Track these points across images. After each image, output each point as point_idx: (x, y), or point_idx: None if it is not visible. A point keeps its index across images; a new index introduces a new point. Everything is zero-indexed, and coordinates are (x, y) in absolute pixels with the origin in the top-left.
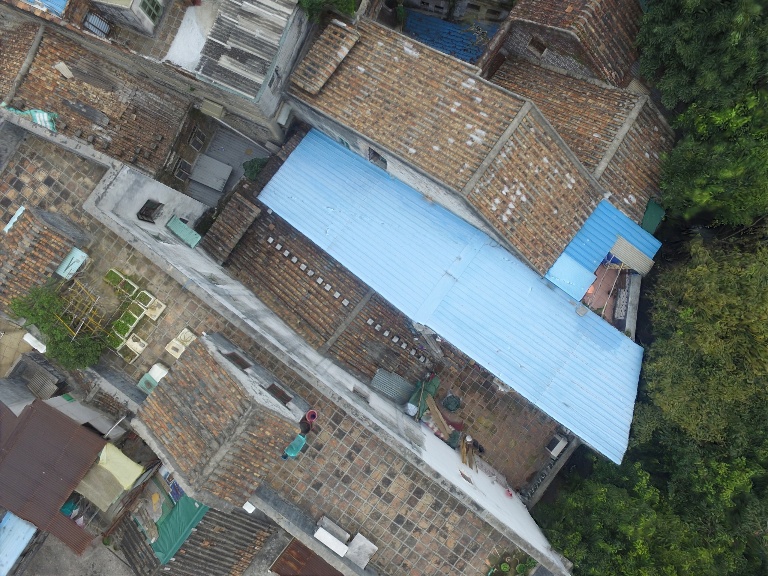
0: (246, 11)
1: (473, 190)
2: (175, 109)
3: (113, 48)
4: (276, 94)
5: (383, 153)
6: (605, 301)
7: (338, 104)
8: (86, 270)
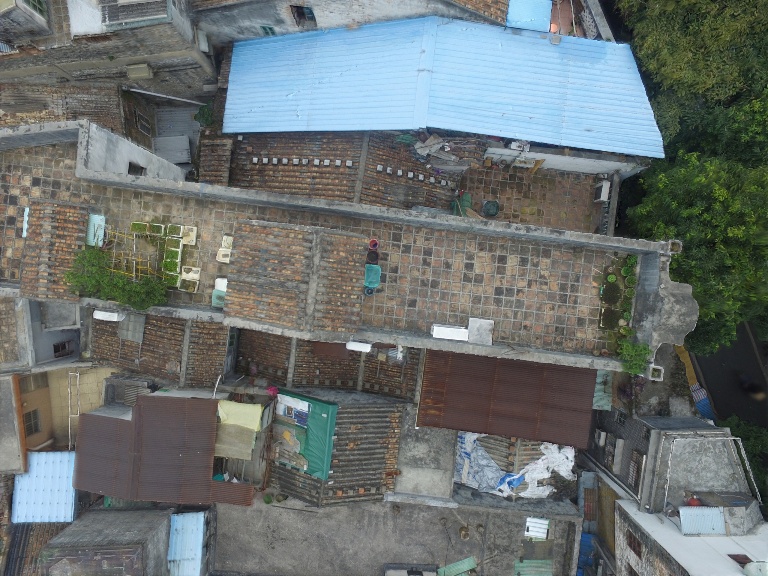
0: None
1: None
2: (108, 99)
3: (23, 59)
4: (185, 17)
5: (305, 0)
6: None
7: None
8: None
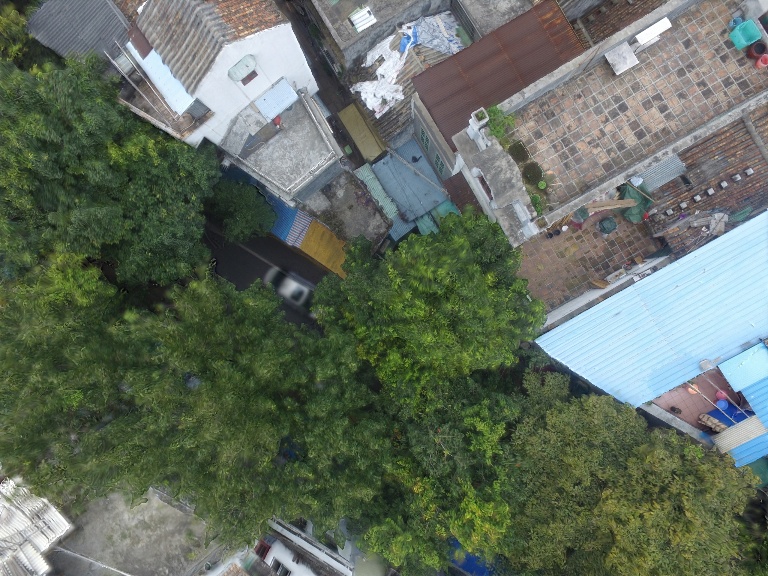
0: None
1: None
2: None
3: None
4: None
5: None
6: (666, 401)
7: None
8: None
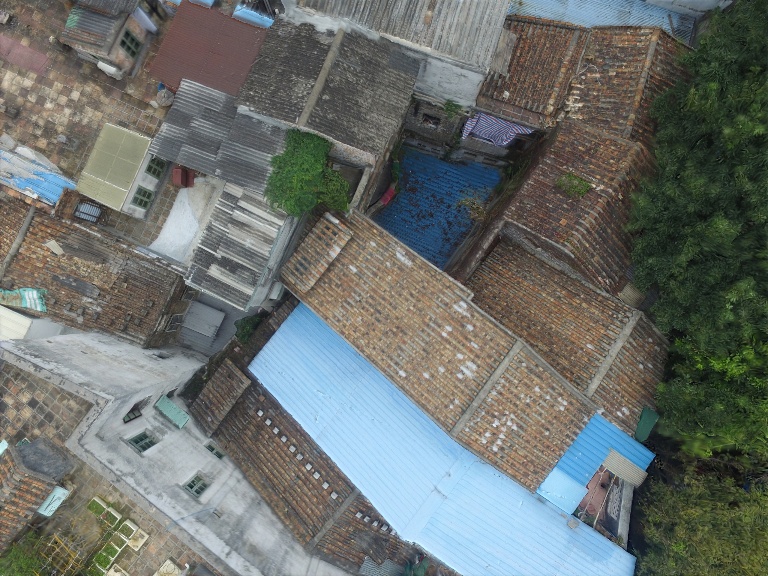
0: (237, 220)
1: (463, 429)
2: (167, 274)
3: None
4: (267, 284)
5: None
6: (598, 493)
7: (329, 304)
8: (68, 497)
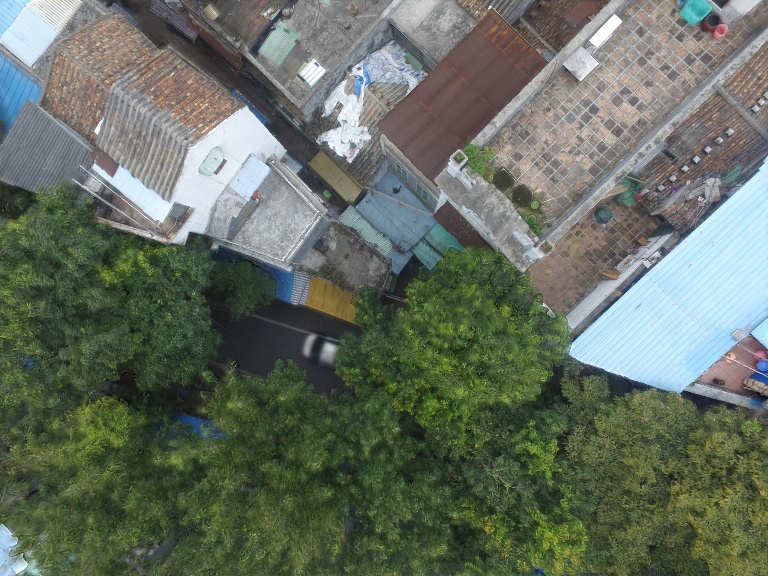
0: None
1: None
2: None
3: None
4: None
5: None
6: (707, 375)
7: None
8: None
